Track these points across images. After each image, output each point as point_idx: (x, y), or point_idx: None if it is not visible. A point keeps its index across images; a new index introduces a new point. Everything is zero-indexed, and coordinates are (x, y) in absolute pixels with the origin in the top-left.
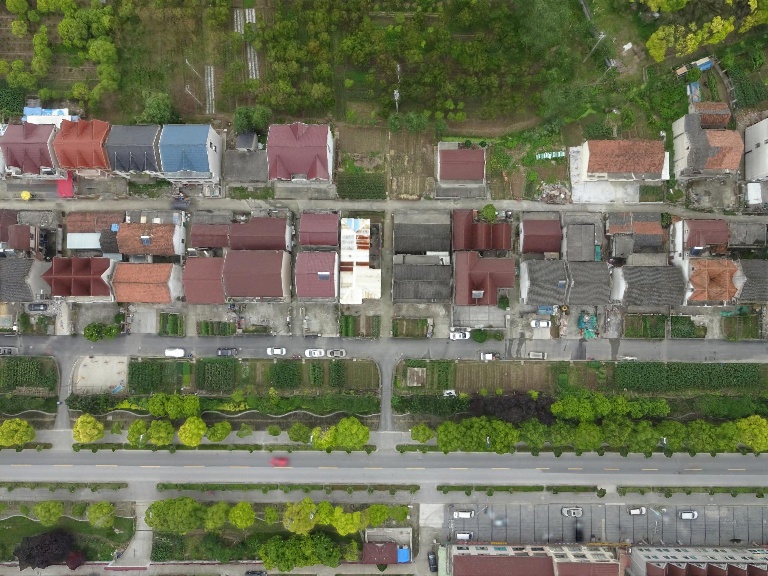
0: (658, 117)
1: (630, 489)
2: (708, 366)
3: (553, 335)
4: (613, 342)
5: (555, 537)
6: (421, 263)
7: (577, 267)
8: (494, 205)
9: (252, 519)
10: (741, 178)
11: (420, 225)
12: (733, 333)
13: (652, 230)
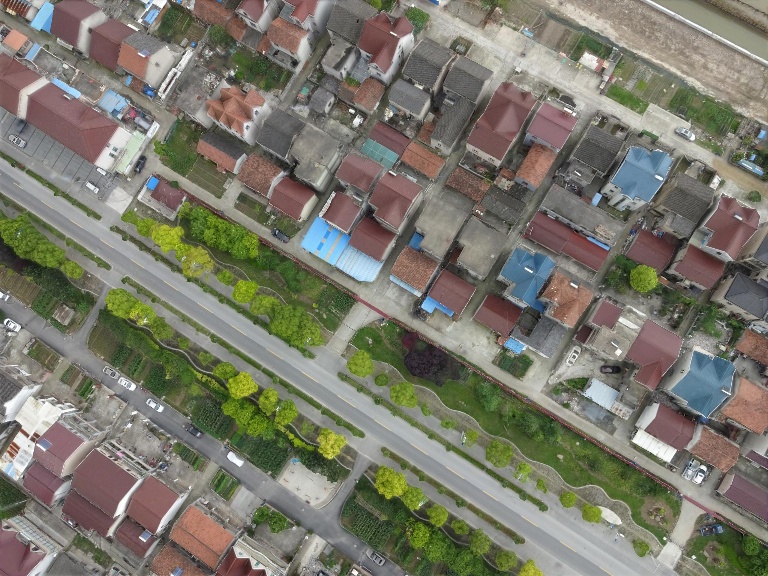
0: None
1: None
2: None
3: None
4: None
5: None
6: None
7: None
8: None
9: None
10: None
11: None
12: None
13: None
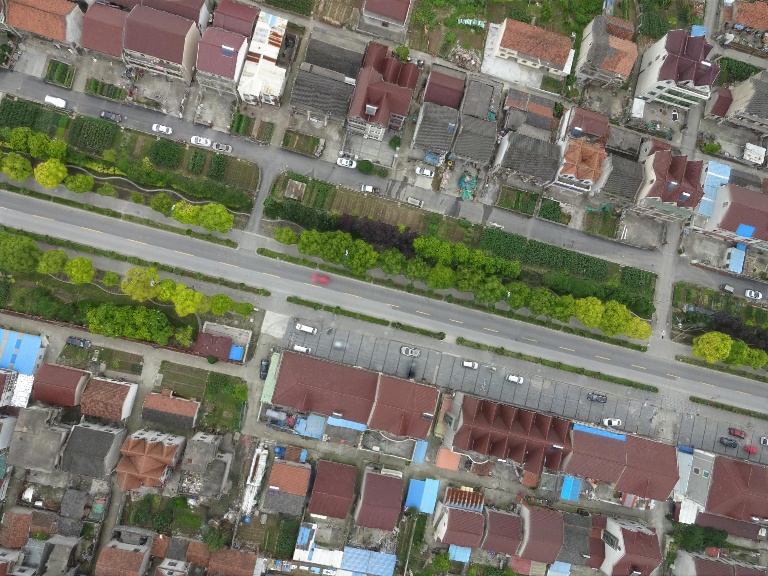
0: (573, 20)
1: (468, 343)
2: (564, 251)
3: (434, 187)
4: (486, 208)
5: (388, 372)
6: (326, 76)
7: (469, 120)
8: (409, 53)
9: (90, 275)
10: (631, 94)
11: (335, 46)
12: (593, 228)
13: (544, 112)
